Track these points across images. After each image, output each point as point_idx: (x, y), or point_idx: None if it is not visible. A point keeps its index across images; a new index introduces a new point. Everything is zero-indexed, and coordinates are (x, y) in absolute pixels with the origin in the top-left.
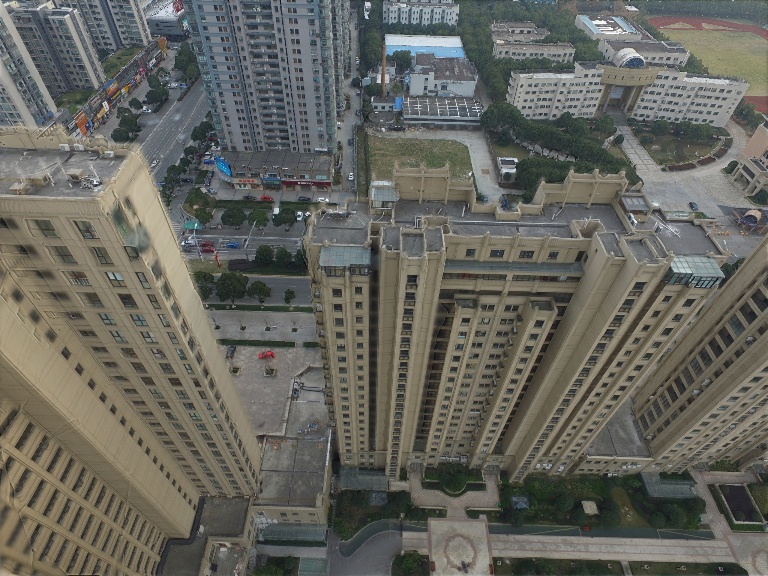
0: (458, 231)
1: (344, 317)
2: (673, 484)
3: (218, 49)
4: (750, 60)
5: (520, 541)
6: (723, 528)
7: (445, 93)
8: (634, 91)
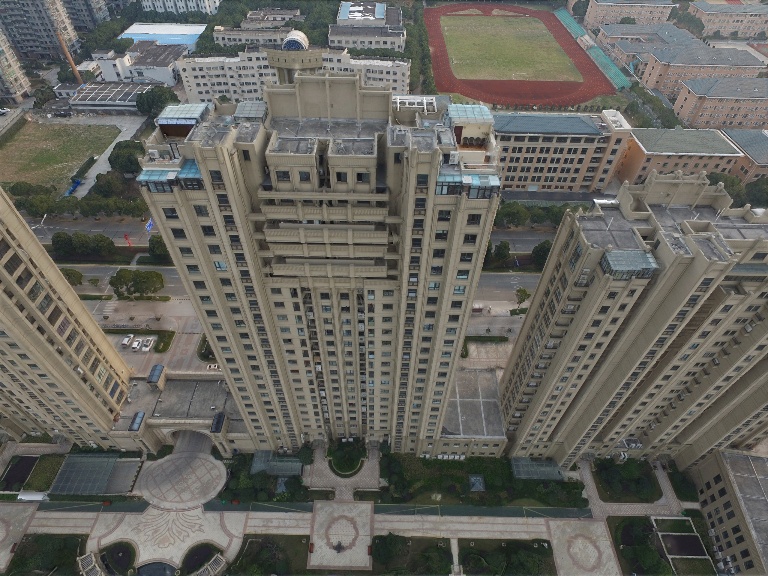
0: None
1: None
2: None
3: None
4: (505, 44)
5: None
6: None
7: (140, 79)
8: None
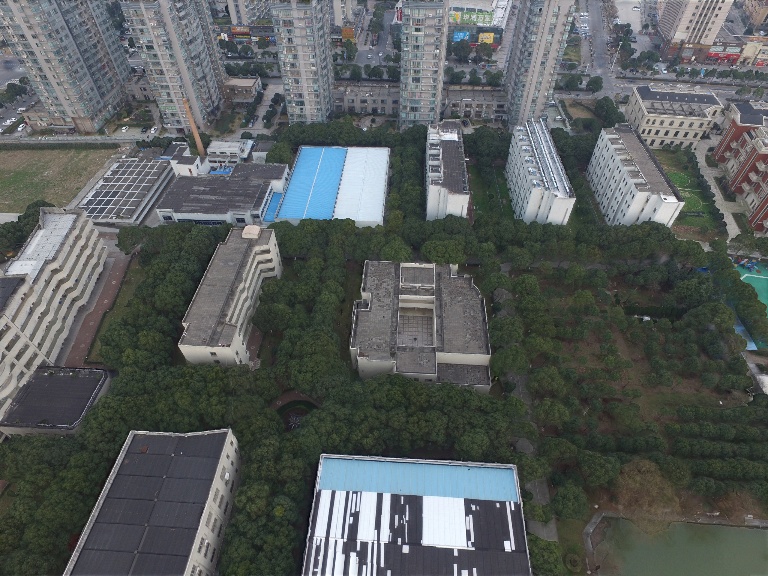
0: None
1: None
2: None
3: None
4: None
5: None
6: None
7: None
8: None
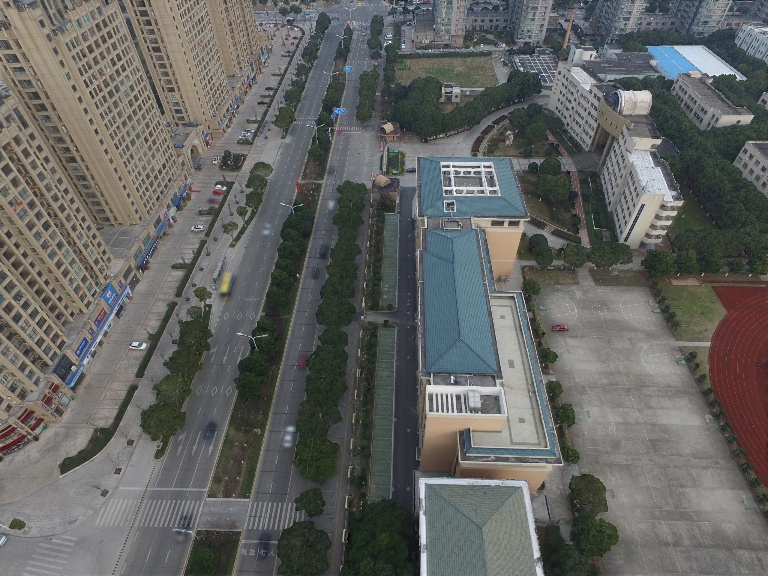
0: None
1: None
2: None
3: None
4: None
5: None
6: None
7: None
8: (610, 139)
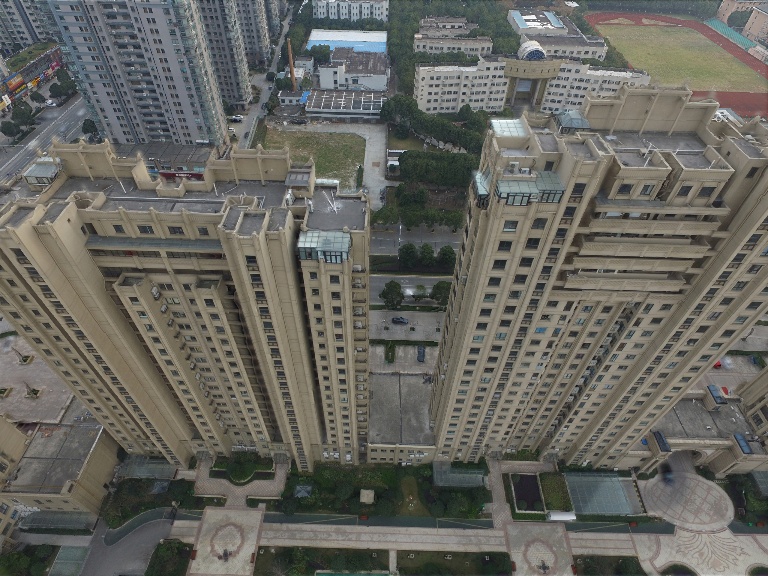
0: (110, 207)
1: (3, 295)
2: (462, 473)
3: (79, 39)
4: (680, 55)
5: (292, 530)
6: (505, 517)
7: (356, 87)
8: (539, 84)
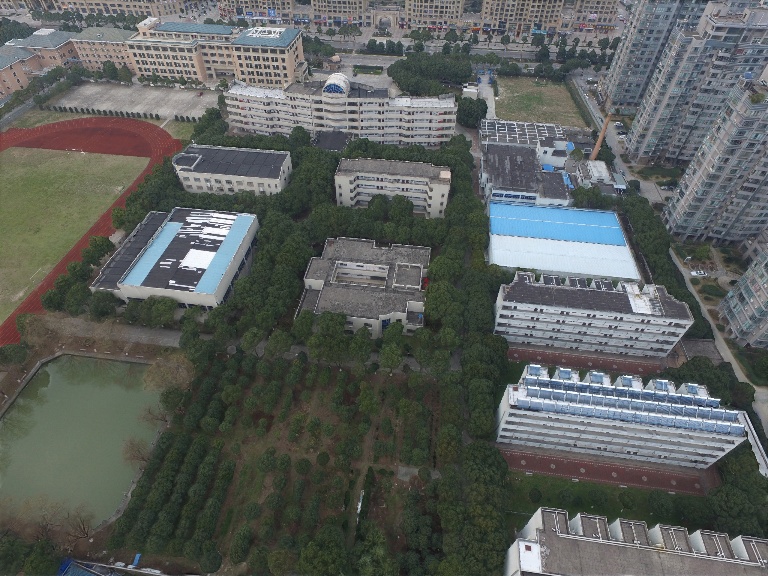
0: None
1: None
2: None
3: None
4: None
5: None
6: None
7: None
8: None
